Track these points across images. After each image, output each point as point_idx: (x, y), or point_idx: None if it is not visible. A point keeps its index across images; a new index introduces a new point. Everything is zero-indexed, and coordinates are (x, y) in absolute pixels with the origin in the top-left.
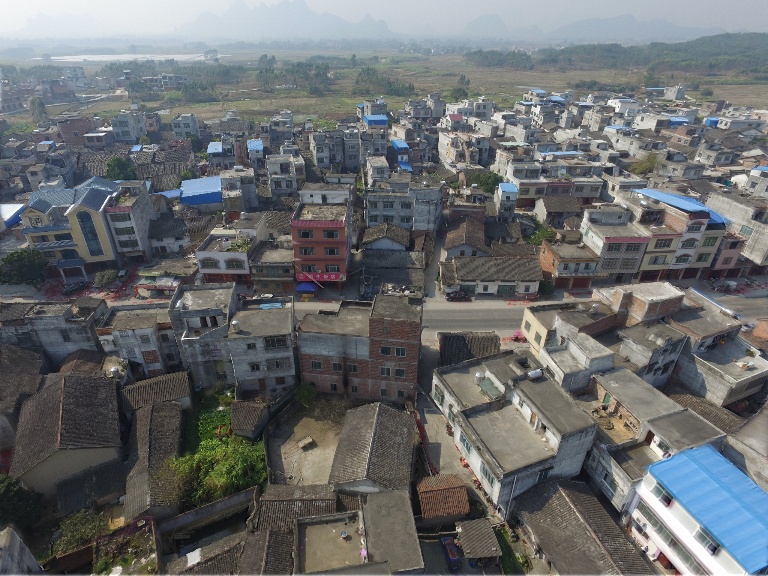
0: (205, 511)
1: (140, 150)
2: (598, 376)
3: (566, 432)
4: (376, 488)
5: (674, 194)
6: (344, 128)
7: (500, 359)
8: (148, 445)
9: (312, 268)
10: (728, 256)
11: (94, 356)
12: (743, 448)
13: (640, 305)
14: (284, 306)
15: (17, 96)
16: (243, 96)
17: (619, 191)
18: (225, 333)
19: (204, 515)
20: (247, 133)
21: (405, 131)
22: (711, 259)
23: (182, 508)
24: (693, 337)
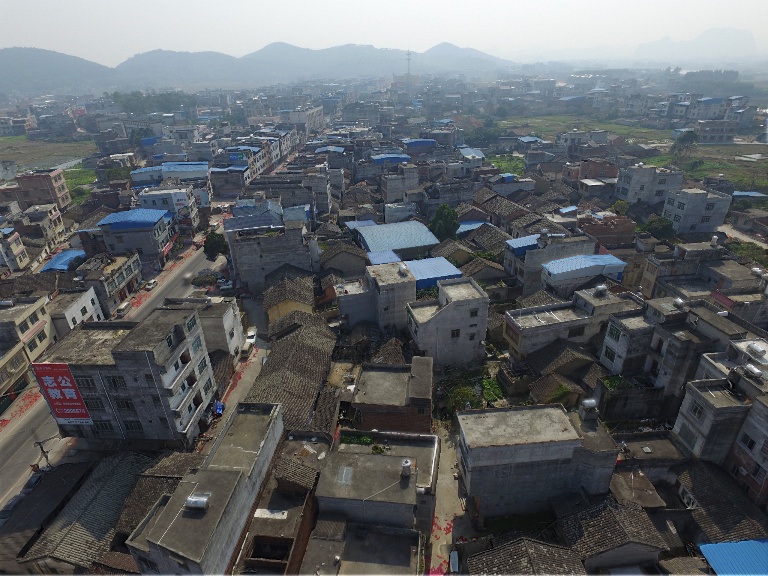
0: None
1: (568, 213)
2: None
3: None
4: None
5: None
6: None
7: None
8: None
9: None
10: None
11: None
12: None
13: None
14: None
15: (733, 128)
16: None
17: None
18: None
19: None
20: None
21: None
22: None
23: None
24: None
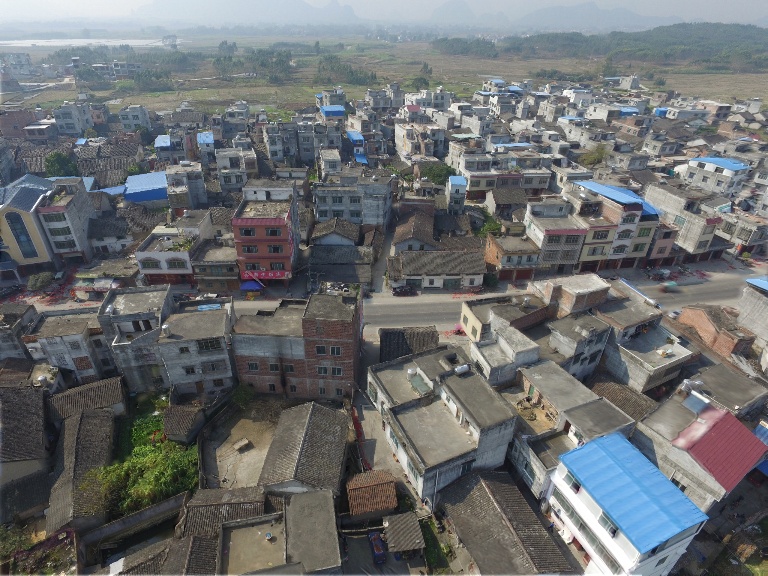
0: (133, 519)
1: (85, 144)
2: (523, 369)
3: (486, 426)
4: (305, 488)
5: (614, 186)
6: (299, 120)
7: (431, 355)
8: (74, 455)
9: (256, 266)
10: (662, 245)
11: (23, 364)
12: (651, 434)
13: (569, 298)
14: (223, 307)
15: None
16: (200, 85)
17: (566, 182)
18: (158, 337)
19: (132, 523)
20: (201, 124)
21: (361, 123)
22: (647, 249)
23: (108, 518)
24: (616, 327)
